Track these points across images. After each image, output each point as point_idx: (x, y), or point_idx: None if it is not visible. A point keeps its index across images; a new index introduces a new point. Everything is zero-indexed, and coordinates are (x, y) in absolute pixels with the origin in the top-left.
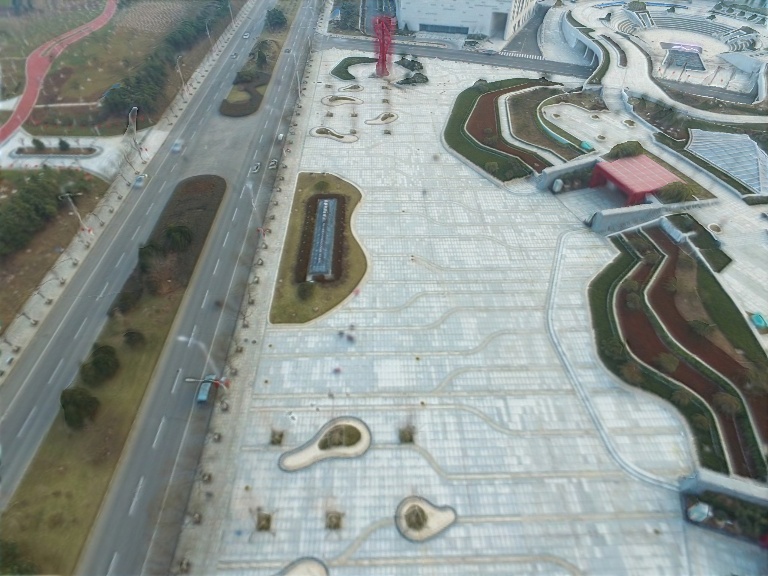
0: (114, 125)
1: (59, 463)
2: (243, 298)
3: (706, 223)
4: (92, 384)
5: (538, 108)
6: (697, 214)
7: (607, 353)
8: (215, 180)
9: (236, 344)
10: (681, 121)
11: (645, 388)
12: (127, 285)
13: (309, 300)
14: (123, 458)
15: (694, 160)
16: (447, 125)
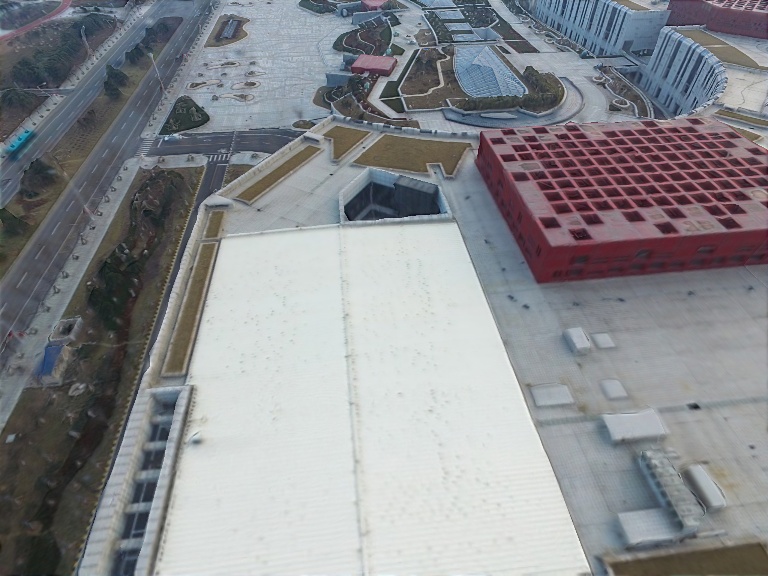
0: (120, 4)
1: None
2: (193, 43)
3: None
4: None
5: None
6: (397, 13)
7: (334, 44)
8: (177, 17)
9: (190, 51)
10: None
11: (344, 51)
12: None
13: (221, 42)
14: (150, 69)
15: None
16: None
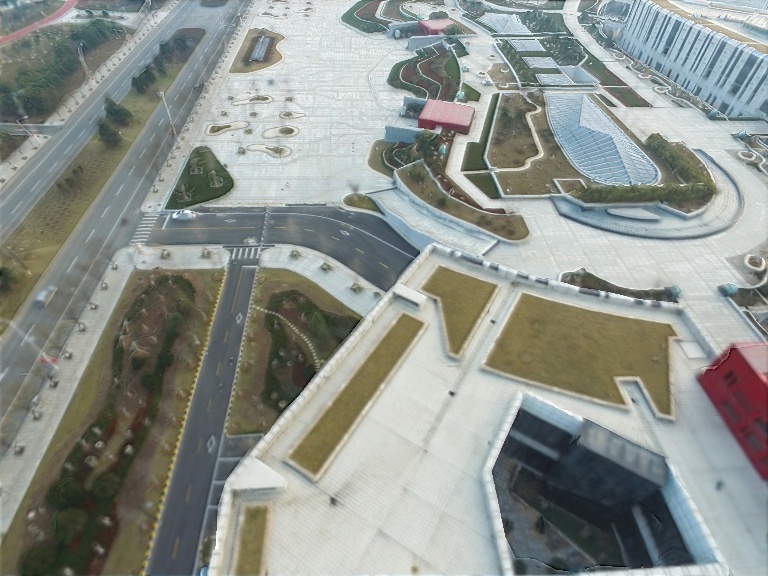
0: (133, 8)
1: (134, 100)
2: (215, 66)
3: (464, 42)
4: None
5: (402, 4)
6: None
7: (389, 78)
8: (199, 29)
9: (212, 77)
10: (480, 7)
11: (402, 88)
12: (154, 60)
13: (250, 66)
14: None
15: (477, 22)
16: (345, 13)
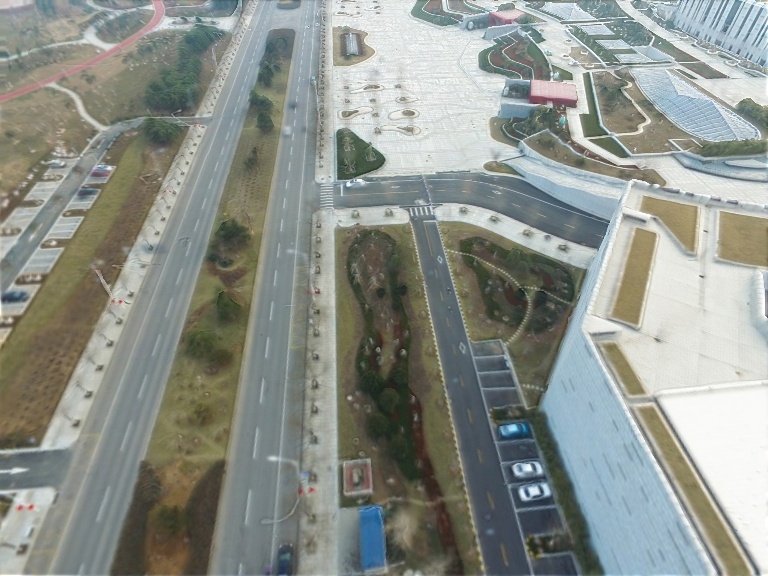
0: (219, 13)
1: None
2: (319, 61)
3: (538, 29)
4: None
5: None
6: None
7: (482, 64)
8: (289, 29)
9: (321, 71)
10: None
11: (496, 73)
12: (264, 58)
13: (350, 60)
14: (287, 93)
15: (542, 12)
16: (412, 9)
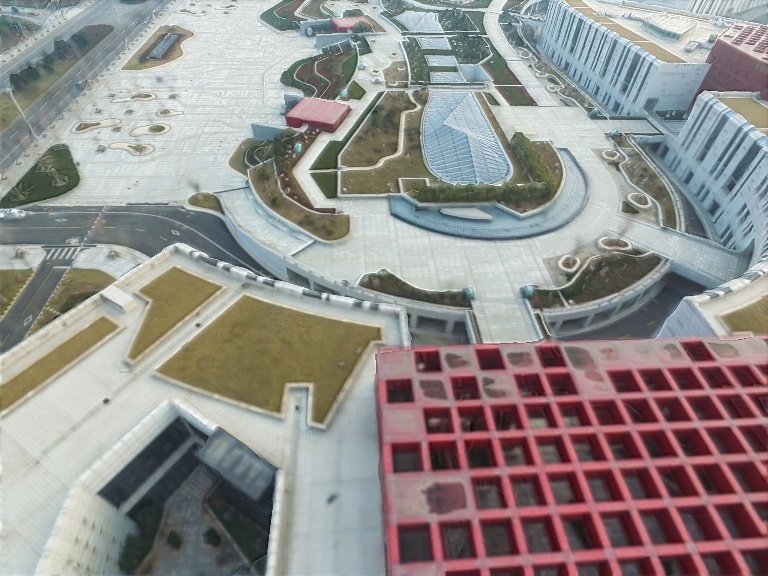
0: None
1: None
2: (110, 63)
3: None
4: (25, 79)
5: None
6: None
7: (282, 76)
8: (107, 26)
9: (101, 74)
10: (400, 5)
11: (293, 86)
12: (47, 56)
13: (144, 64)
14: (39, 99)
15: (392, 20)
16: (266, 11)
